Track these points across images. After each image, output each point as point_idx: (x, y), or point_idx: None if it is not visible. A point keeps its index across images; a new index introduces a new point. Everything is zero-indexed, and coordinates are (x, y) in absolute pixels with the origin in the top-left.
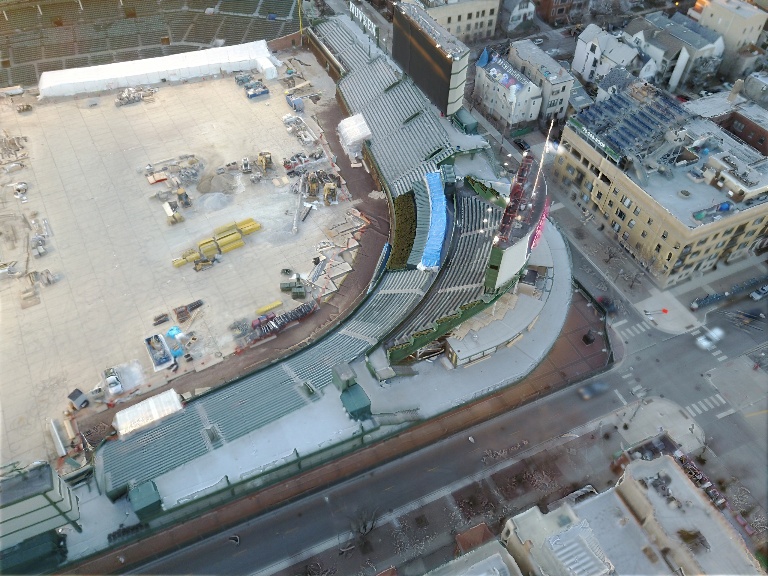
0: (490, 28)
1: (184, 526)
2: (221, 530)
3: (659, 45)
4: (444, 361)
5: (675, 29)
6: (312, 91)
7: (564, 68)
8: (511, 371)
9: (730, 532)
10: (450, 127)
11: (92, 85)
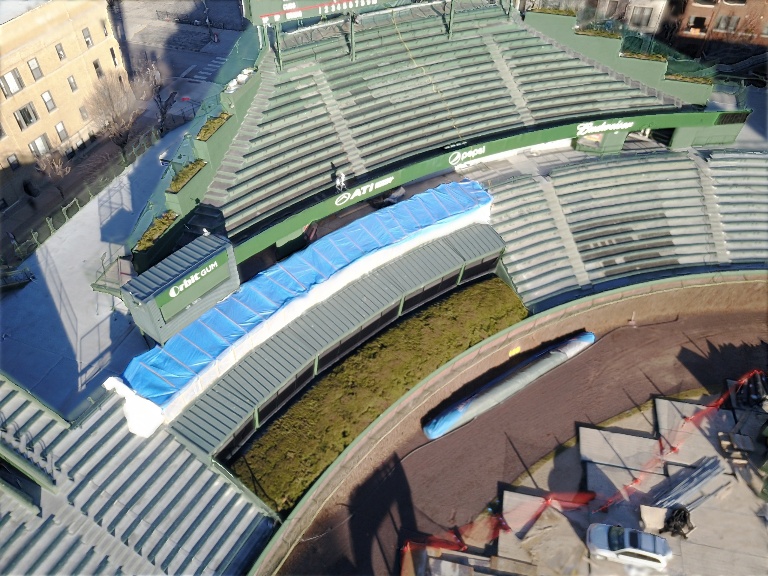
0: None
1: None
2: None
3: None
4: None
5: None
6: None
7: None
8: None
9: None
10: None
11: None
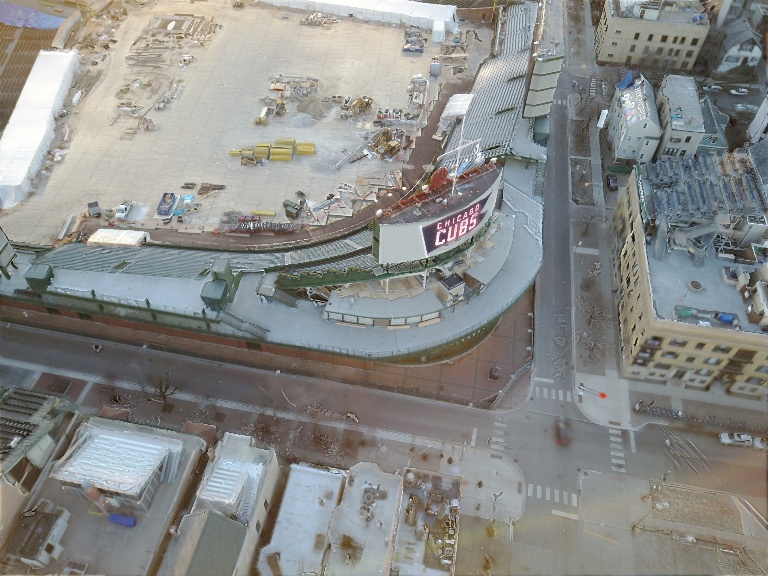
0: (688, 60)
1: (81, 321)
2: (96, 336)
3: None
4: None
5: None
6: (462, 63)
7: (703, 118)
8: (369, 347)
9: (384, 566)
10: (525, 130)
11: (295, 2)
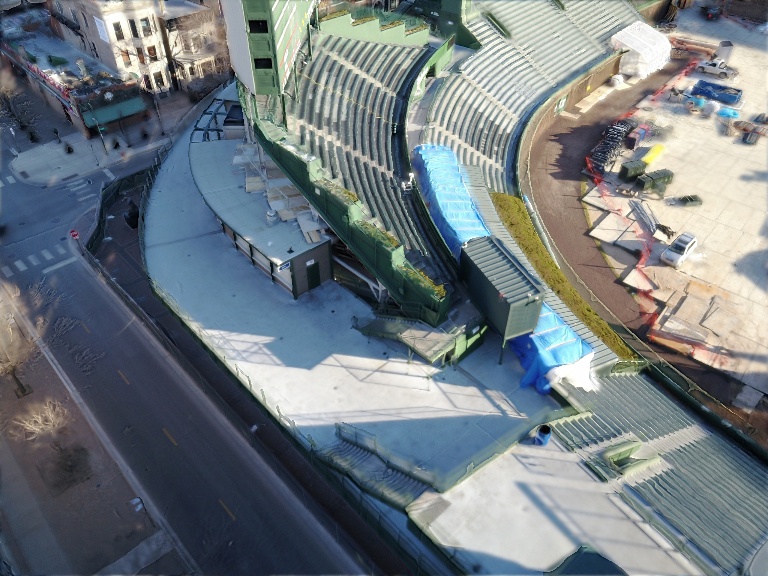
0: None
1: None
2: None
3: None
4: None
5: None
6: None
7: None
8: None
9: None
10: None
11: None
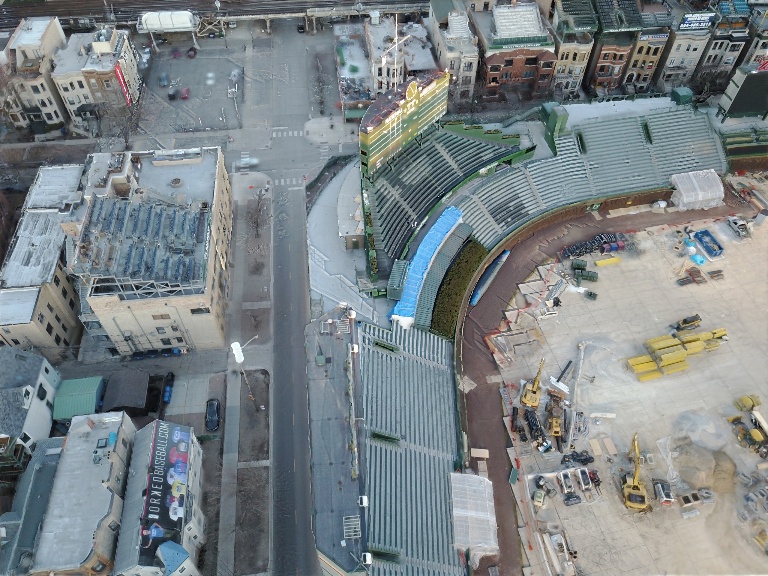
0: None
1: None
2: None
3: None
4: None
5: None
6: None
7: (65, 443)
8: None
9: None
10: None
11: None
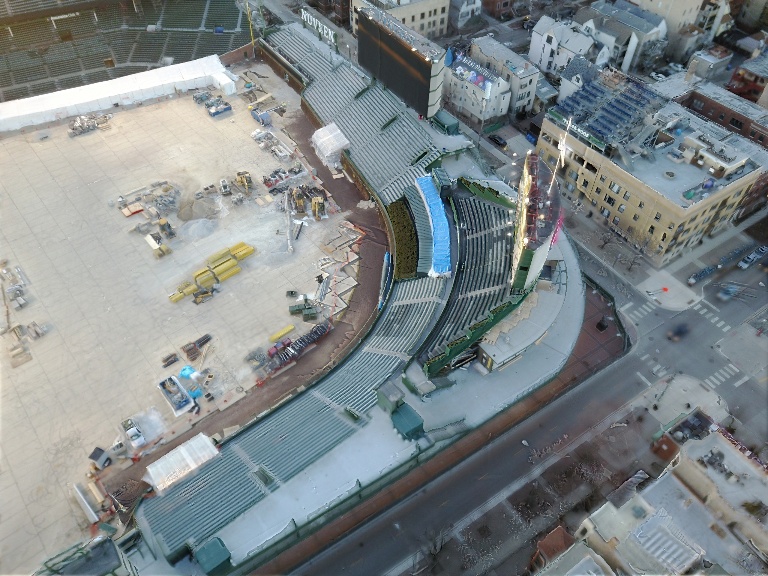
0: (442, 26)
1: None
2: (285, 574)
3: (609, 32)
4: (478, 367)
5: (621, 15)
6: (276, 104)
7: (528, 61)
8: (545, 368)
9: None
10: (431, 129)
11: (39, 117)
